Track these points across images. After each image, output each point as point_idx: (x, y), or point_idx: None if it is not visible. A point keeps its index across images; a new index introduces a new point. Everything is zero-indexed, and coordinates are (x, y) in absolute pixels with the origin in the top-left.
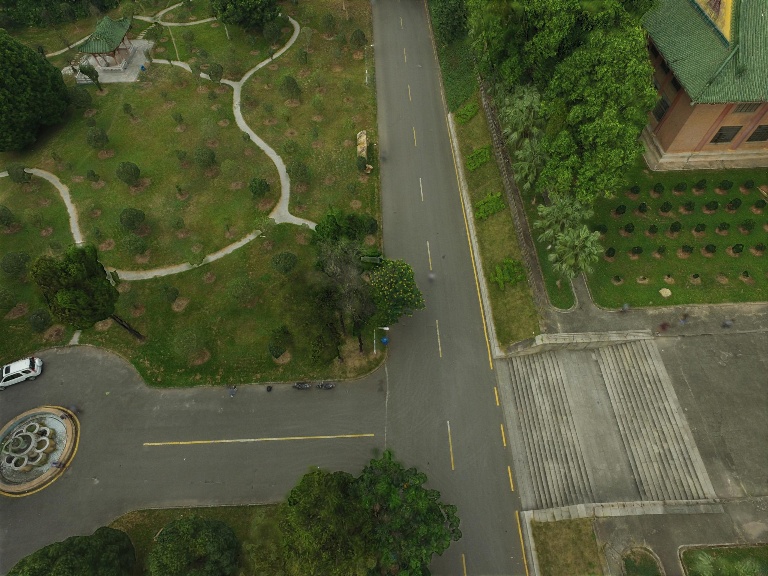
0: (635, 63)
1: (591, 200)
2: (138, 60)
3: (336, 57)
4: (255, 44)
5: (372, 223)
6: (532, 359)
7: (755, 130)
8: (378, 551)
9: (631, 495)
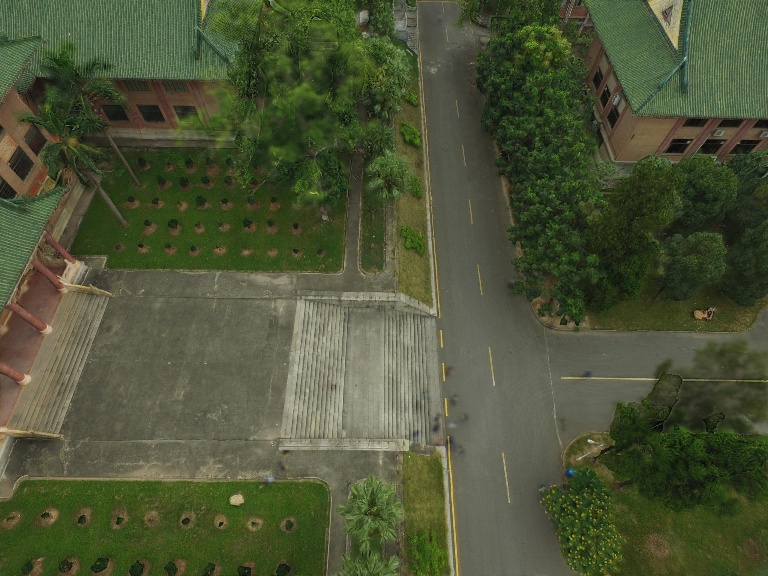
0: None
1: None
2: None
3: None
4: None
5: None
6: None
7: None
8: (581, 233)
9: (355, 314)
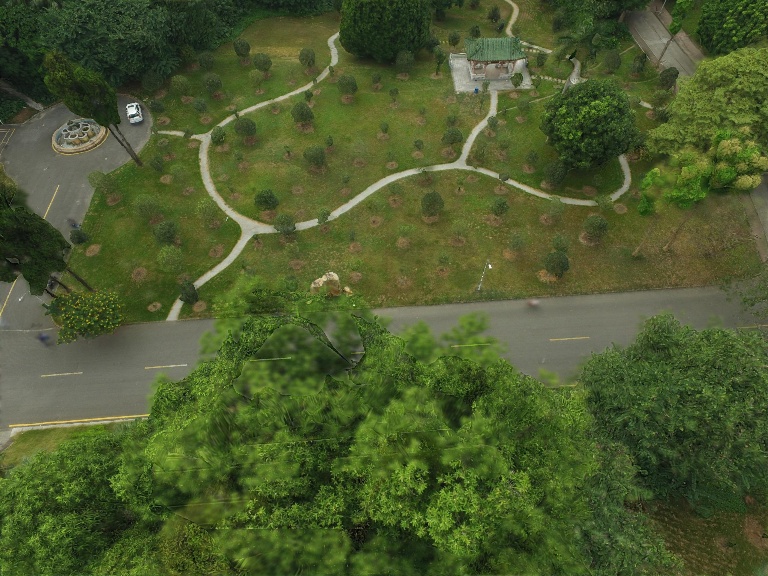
0: None
1: None
2: (492, 85)
3: None
4: None
5: None
6: None
7: None
8: None
9: None
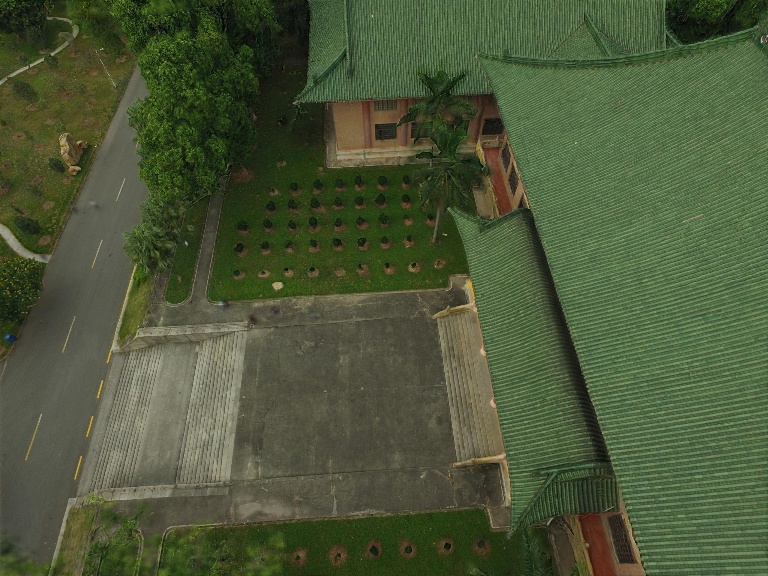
0: (167, 65)
1: (168, 197)
2: None
3: (87, 61)
4: (26, 49)
5: (28, 223)
6: (144, 352)
7: (412, 127)
8: None
9: (168, 480)
